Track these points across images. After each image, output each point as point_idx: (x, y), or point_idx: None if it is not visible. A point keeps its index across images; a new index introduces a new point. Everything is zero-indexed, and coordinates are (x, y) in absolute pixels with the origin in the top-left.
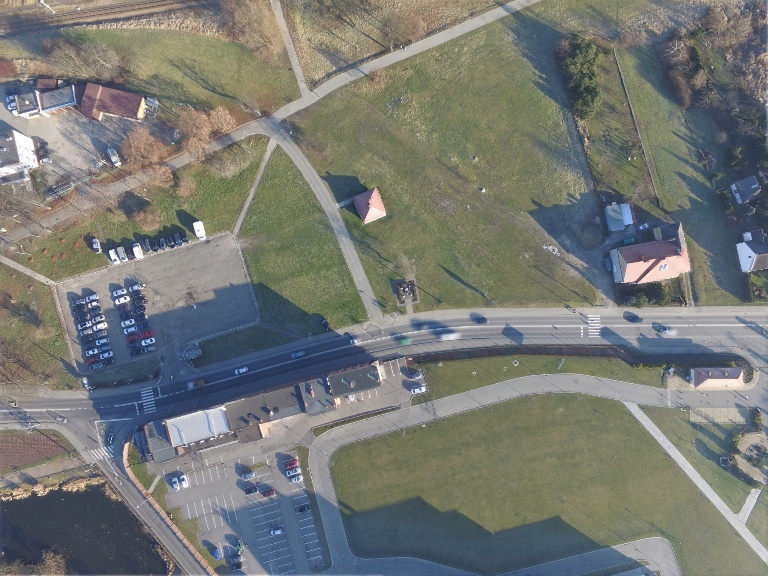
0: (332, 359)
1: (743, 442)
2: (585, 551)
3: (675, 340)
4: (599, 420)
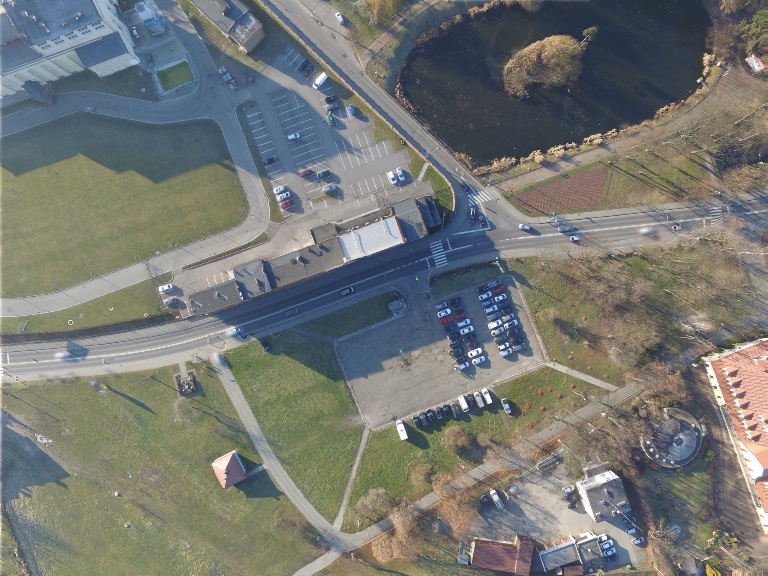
0: (257, 311)
1: None
2: None
3: None
4: None
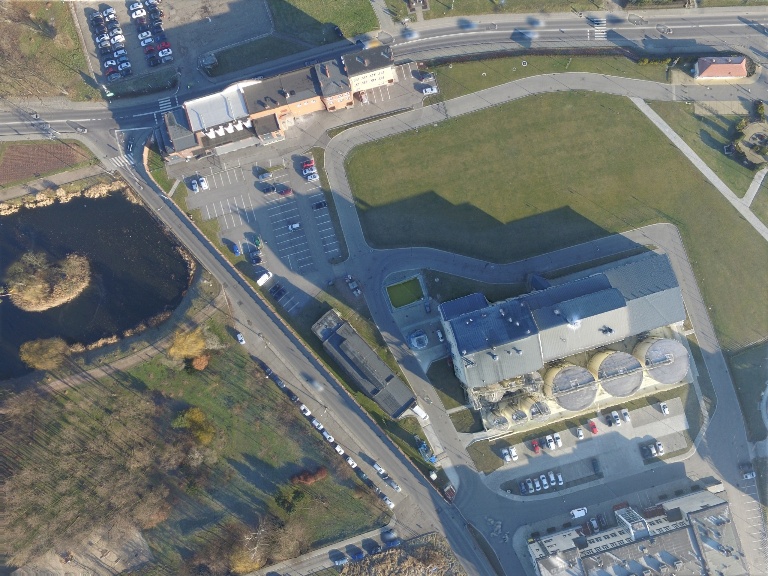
0: None
1: (746, 131)
2: (594, 238)
3: (679, 41)
4: (606, 115)
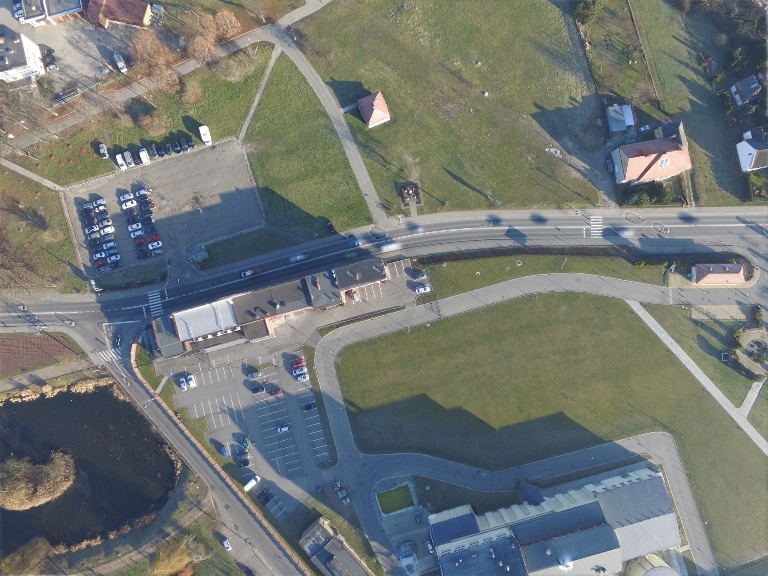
0: (337, 261)
1: (744, 338)
2: (588, 446)
3: (676, 240)
4: (602, 318)
